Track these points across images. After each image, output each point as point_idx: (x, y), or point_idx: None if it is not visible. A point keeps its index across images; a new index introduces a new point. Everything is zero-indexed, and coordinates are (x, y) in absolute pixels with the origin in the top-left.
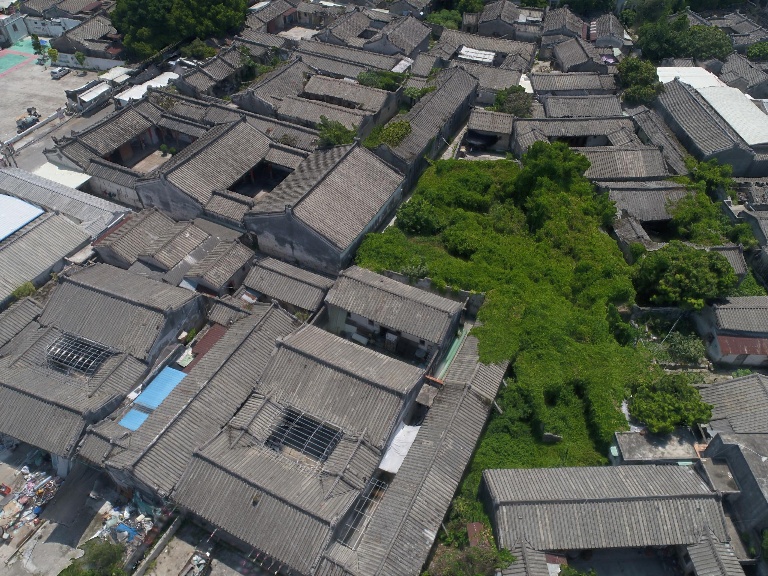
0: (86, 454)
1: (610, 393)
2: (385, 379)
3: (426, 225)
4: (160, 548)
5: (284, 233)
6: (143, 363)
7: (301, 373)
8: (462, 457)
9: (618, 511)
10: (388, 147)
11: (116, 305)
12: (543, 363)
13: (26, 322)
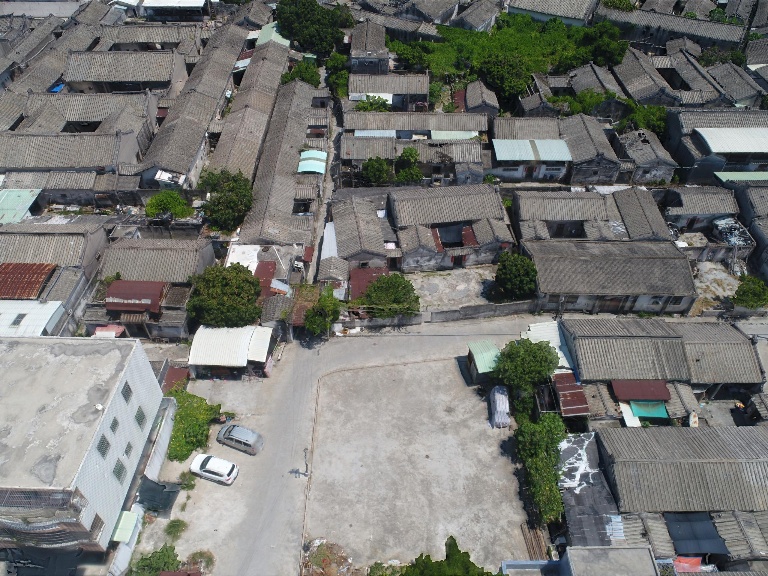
0: None
1: None
2: (424, 6)
3: None
4: None
5: None
6: None
7: None
8: (392, 25)
9: None
10: (600, 2)
11: None
12: None
13: None
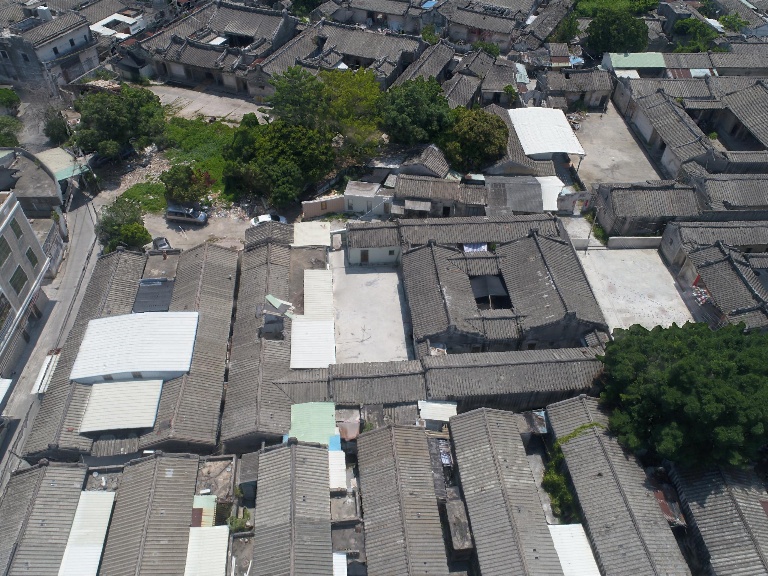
0: (411, 13)
1: (618, 8)
2: None
3: None
4: None
5: None
6: None
7: None
8: (559, 17)
9: None
10: None
11: None
12: (589, 3)
13: None
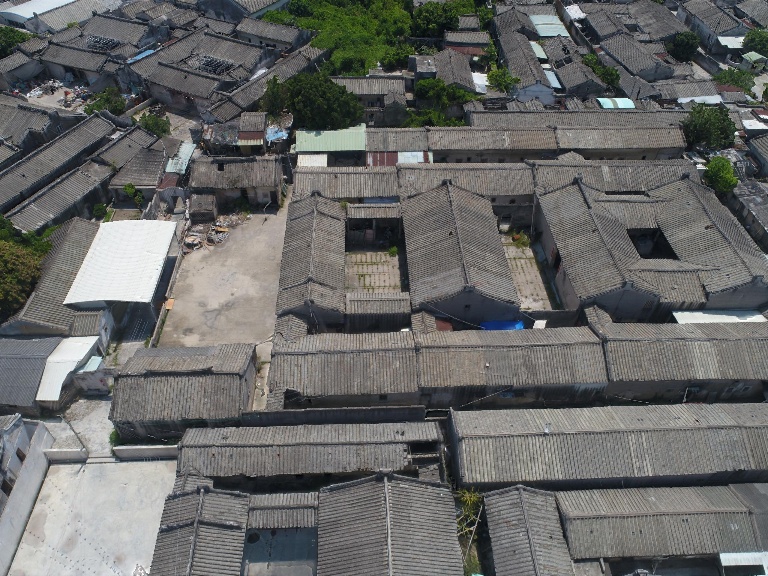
0: (107, 69)
1: (374, 59)
2: None
3: (304, 10)
4: (142, 107)
5: (219, 8)
6: (136, 48)
7: (215, 45)
8: (290, 73)
9: (354, 82)
10: None
11: (123, 24)
12: (345, 51)
13: (75, 36)
